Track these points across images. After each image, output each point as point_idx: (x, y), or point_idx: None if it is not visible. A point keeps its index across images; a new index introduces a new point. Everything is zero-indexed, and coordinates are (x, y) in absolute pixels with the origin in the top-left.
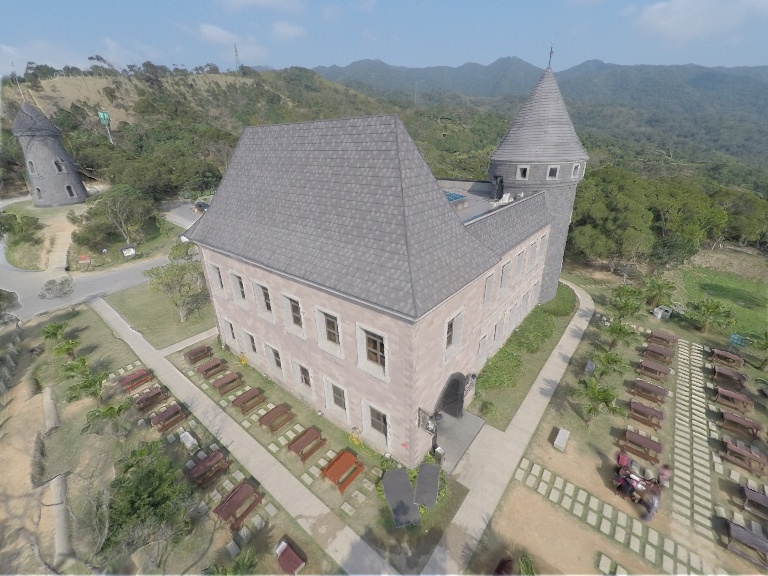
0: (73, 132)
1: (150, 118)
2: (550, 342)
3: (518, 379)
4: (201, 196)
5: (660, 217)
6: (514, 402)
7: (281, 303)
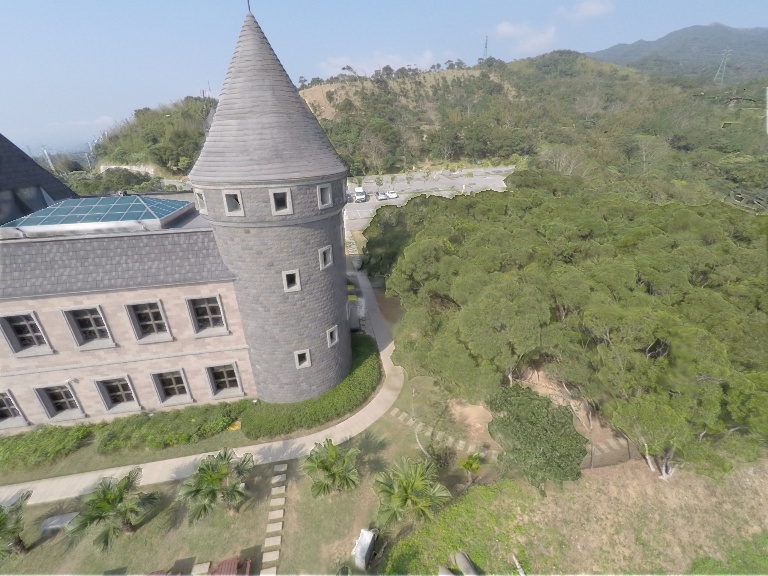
0: None
1: (344, 115)
2: (146, 455)
3: (7, 467)
4: None
5: (596, 347)
6: None
7: None
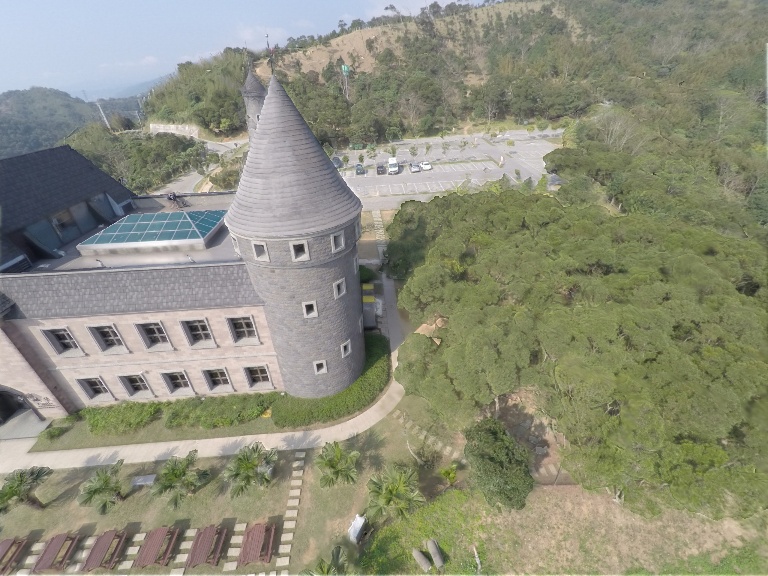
0: (327, 82)
1: (383, 67)
2: (200, 432)
3: (104, 432)
4: (362, 149)
5: None
6: (74, 444)
7: None
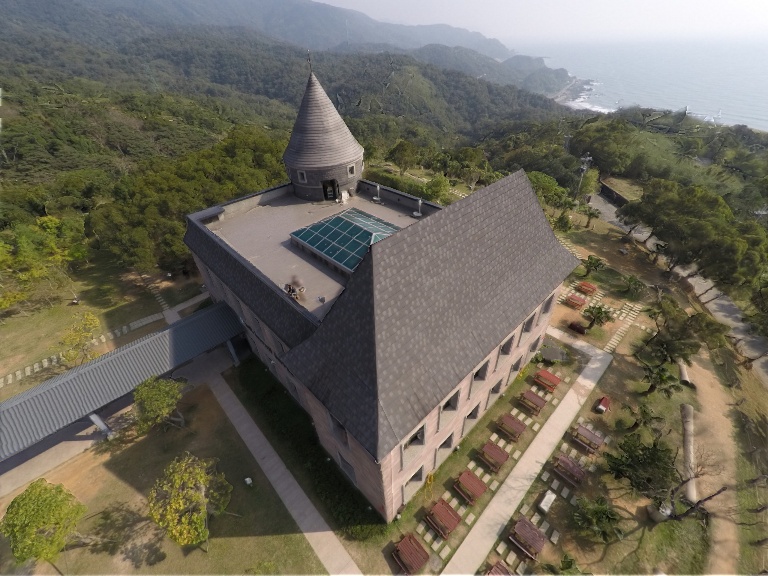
0: None
1: None
2: None
3: None
4: None
5: None
6: None
7: (497, 355)
